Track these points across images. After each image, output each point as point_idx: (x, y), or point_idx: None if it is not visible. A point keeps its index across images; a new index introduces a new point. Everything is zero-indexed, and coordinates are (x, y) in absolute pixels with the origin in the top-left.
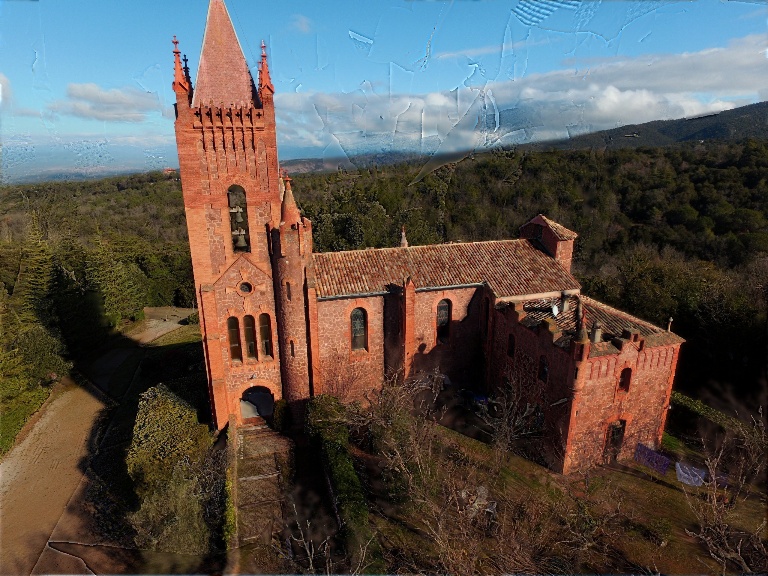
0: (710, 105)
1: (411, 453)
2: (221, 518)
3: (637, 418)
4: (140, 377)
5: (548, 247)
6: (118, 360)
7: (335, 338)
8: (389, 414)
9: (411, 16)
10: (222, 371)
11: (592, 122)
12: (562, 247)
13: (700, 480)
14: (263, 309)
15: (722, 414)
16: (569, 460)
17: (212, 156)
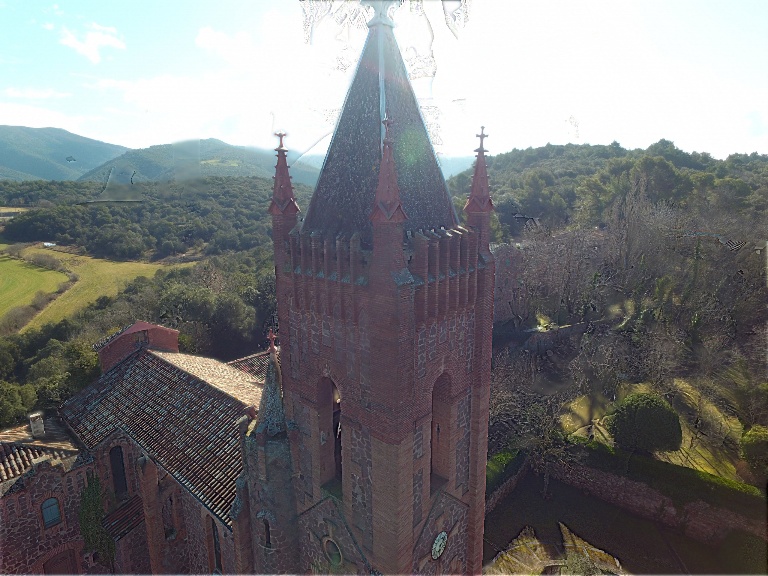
0: None
1: None
2: None
3: None
4: None
5: (165, 347)
6: None
7: None
8: None
9: None
10: None
11: None
12: None
13: None
14: None
15: None
16: None
17: None
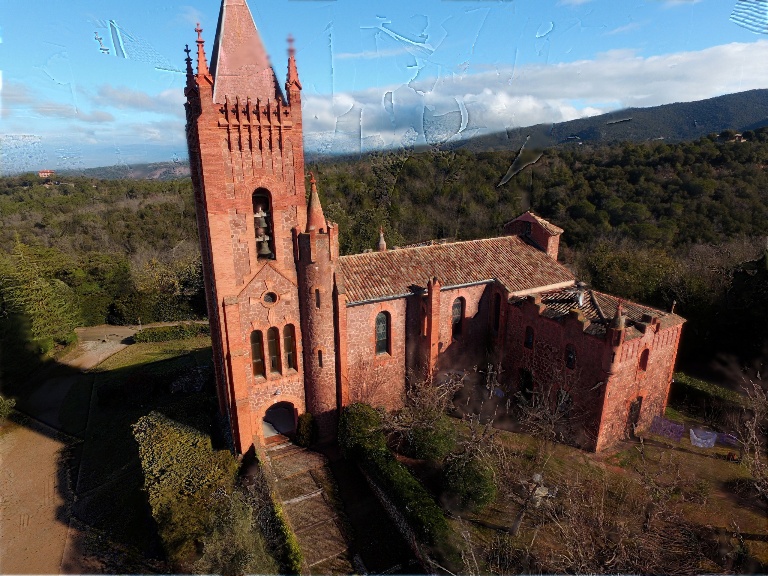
0: (625, 111)
1: (471, 451)
2: (283, 547)
3: (650, 393)
4: (98, 407)
5: (538, 242)
6: (61, 391)
7: (361, 344)
8: (430, 415)
9: (473, 18)
10: (246, 390)
11: (522, 125)
12: (552, 242)
13: (712, 442)
14: (288, 319)
15: (704, 383)
16: (601, 439)
17: (237, 157)
